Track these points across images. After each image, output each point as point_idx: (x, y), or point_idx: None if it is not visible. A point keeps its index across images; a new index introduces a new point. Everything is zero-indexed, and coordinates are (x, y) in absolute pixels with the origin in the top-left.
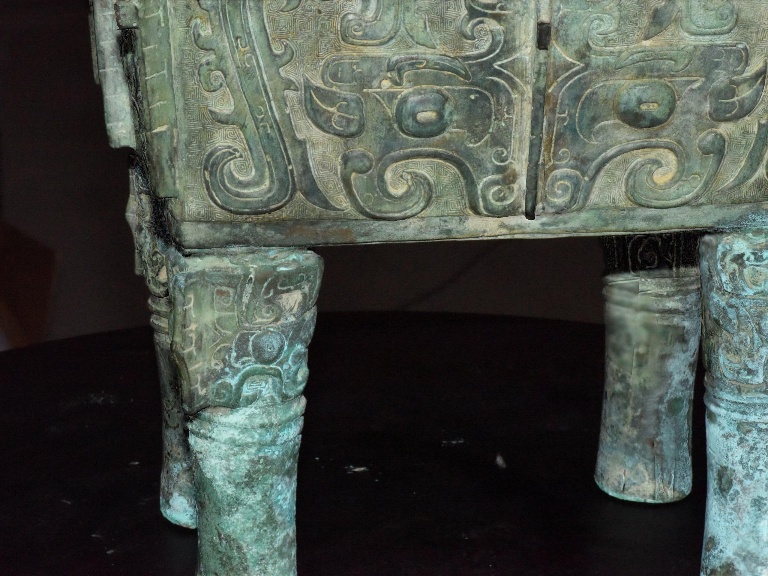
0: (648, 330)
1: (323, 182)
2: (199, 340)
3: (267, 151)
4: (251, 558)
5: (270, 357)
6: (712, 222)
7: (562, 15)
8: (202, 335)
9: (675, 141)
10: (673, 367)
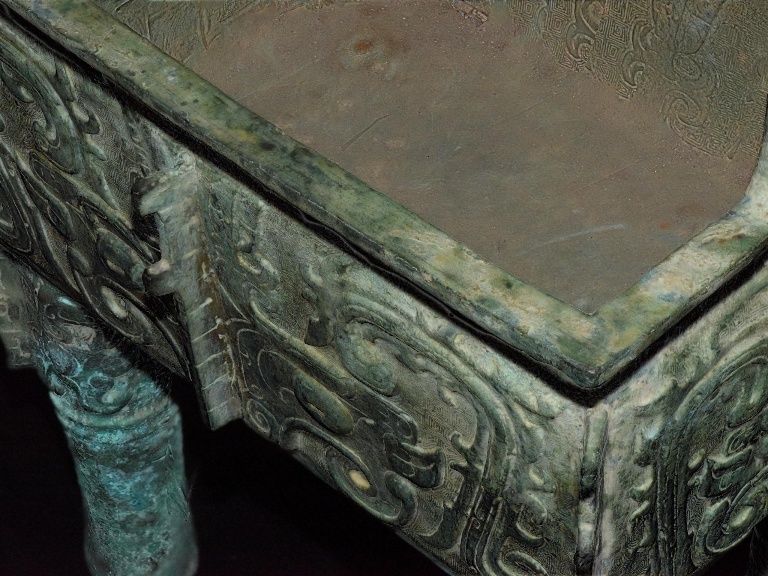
0: (762, 520)
1: (60, 257)
2: (15, 310)
3: (4, 197)
4: (93, 514)
5: (60, 370)
6: (427, 556)
7: (220, 261)
8: (19, 307)
9: (361, 457)
10: None
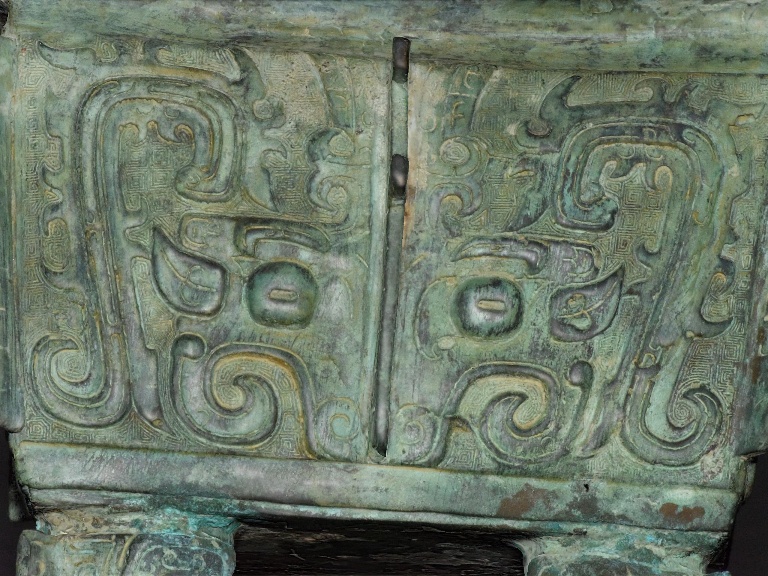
0: None
1: None
2: None
3: None
4: None
5: None
6: None
7: None
8: None
9: None
10: None
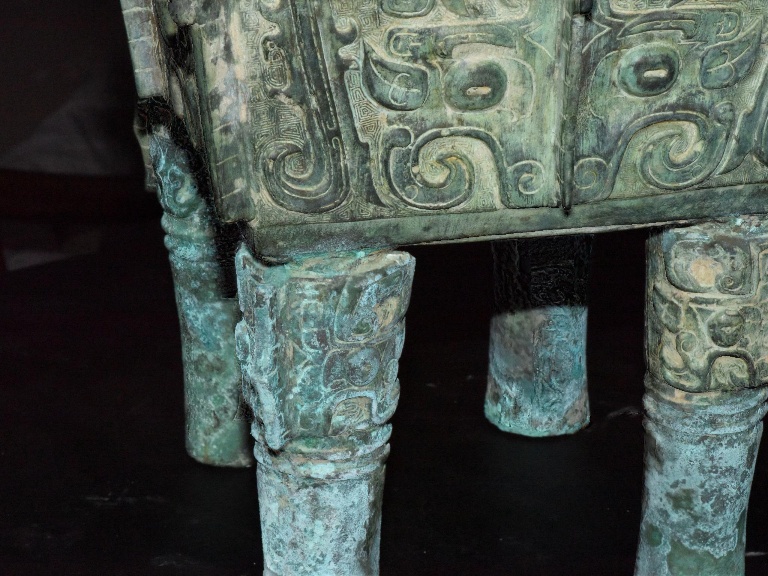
0: None
1: None
2: None
3: None
4: None
5: None
6: None
7: None
8: None
9: None
10: (648, 483)
